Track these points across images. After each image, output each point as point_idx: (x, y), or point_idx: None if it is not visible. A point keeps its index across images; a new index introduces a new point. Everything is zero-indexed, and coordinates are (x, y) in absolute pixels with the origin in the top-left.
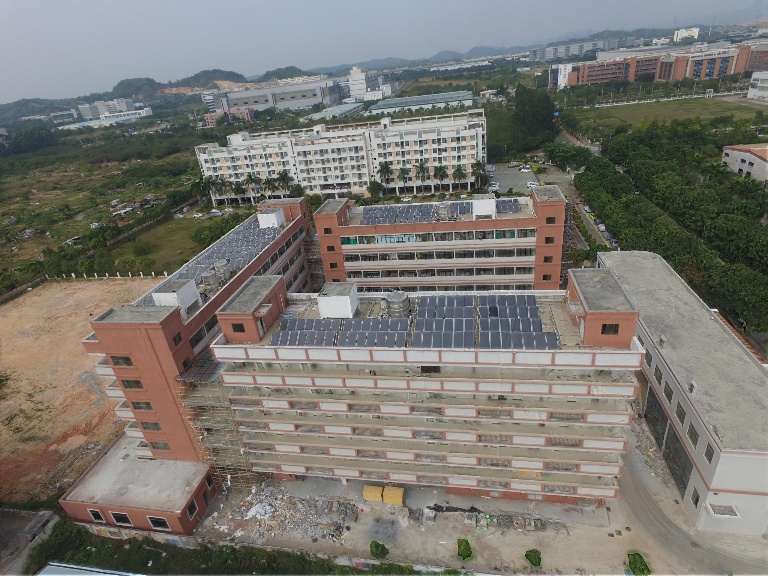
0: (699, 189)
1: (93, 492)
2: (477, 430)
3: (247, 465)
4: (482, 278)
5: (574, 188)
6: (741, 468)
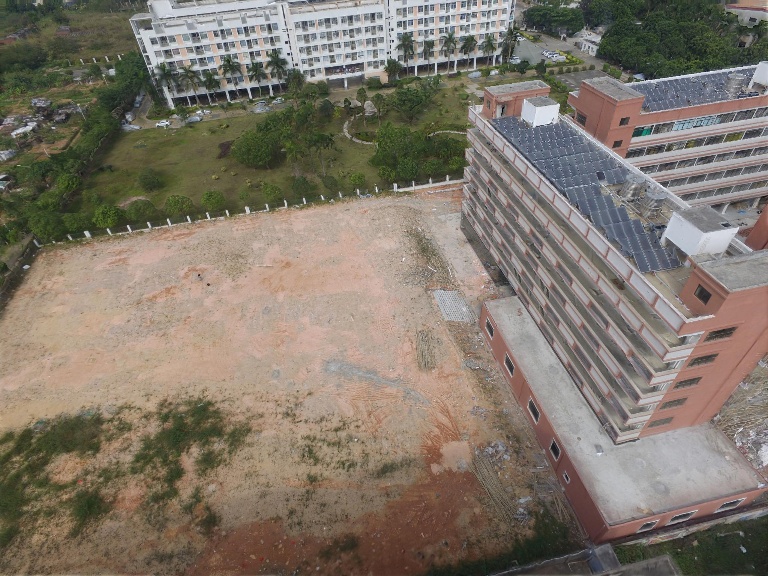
0: (765, 49)
1: (628, 502)
2: None
3: None
4: (755, 158)
5: (592, 56)
6: None
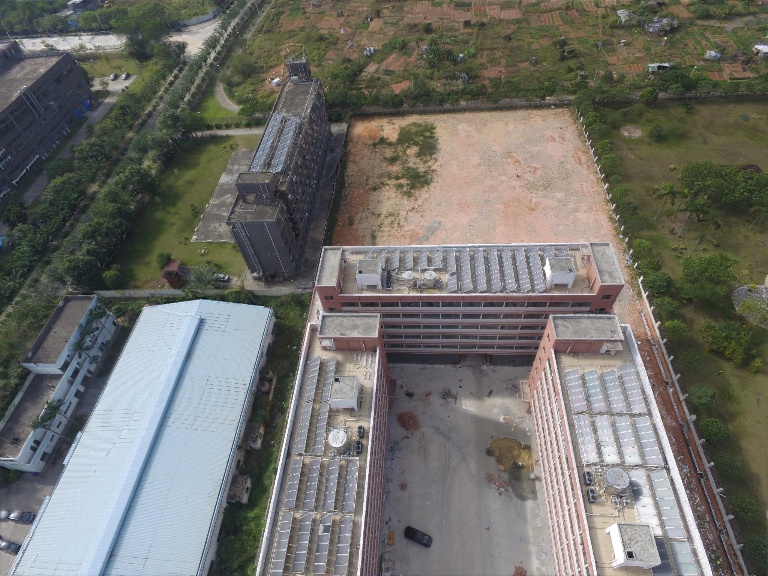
0: None
1: None
2: None
3: None
4: None
5: None
6: None
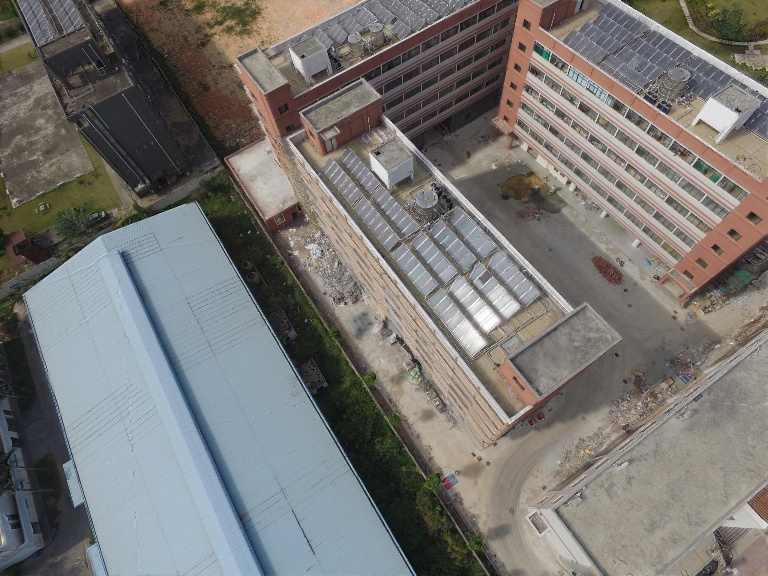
0: None
1: (241, 166)
2: (418, 336)
3: (314, 219)
4: (649, 193)
5: None
6: (559, 527)
